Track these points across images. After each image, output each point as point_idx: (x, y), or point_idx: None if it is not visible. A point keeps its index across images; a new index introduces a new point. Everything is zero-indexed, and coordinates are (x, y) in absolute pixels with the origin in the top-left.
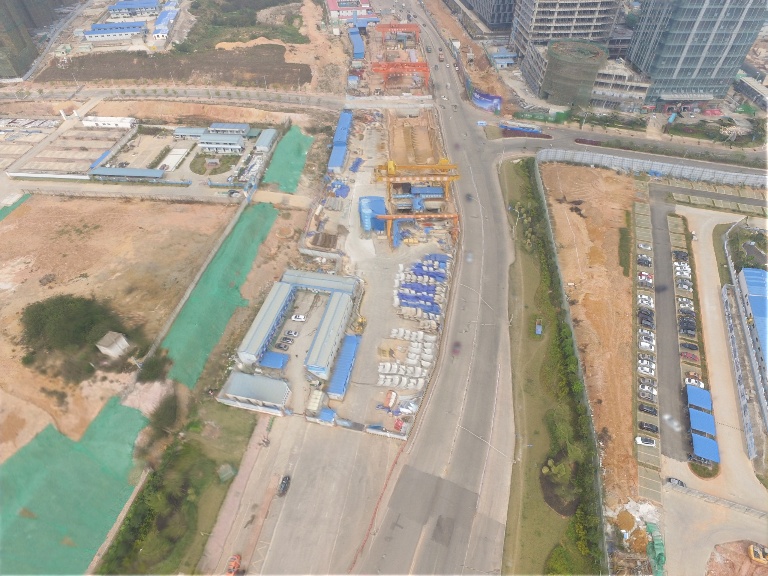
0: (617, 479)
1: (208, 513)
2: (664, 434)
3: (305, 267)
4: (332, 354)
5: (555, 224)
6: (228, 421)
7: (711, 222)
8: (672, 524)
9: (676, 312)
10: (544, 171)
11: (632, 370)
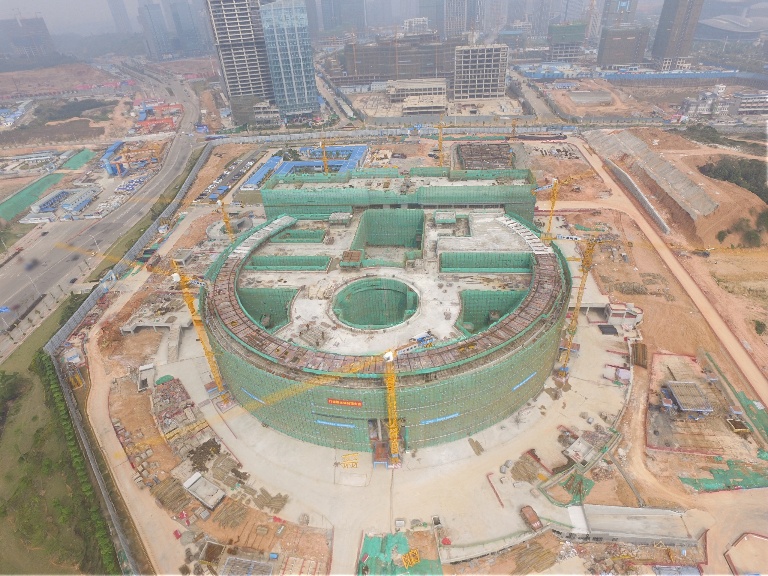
0: None
1: (11, 243)
2: None
3: None
4: (76, 203)
5: None
6: None
7: None
8: None
9: None
10: None
11: None
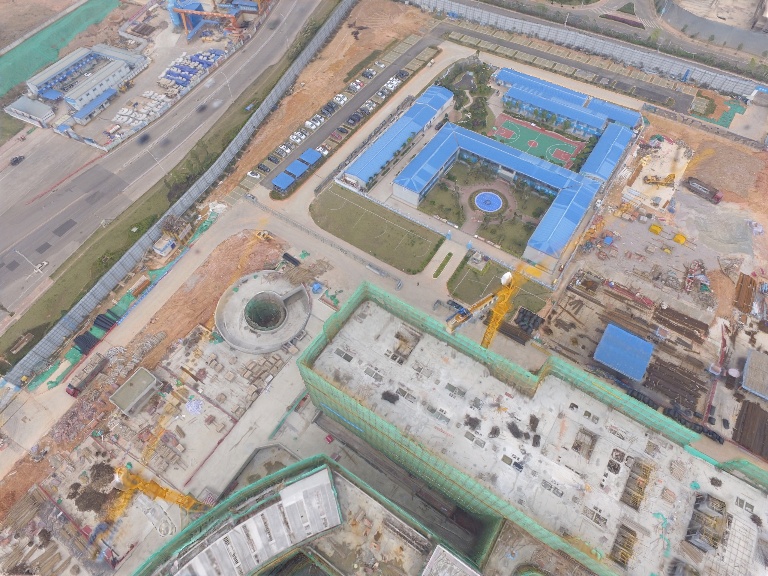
0: (218, 190)
1: None
2: (272, 174)
3: (117, 45)
4: (89, 95)
5: (330, 42)
6: (7, 124)
7: (459, 56)
8: (229, 216)
9: (357, 109)
10: (361, 2)
11: (287, 137)
